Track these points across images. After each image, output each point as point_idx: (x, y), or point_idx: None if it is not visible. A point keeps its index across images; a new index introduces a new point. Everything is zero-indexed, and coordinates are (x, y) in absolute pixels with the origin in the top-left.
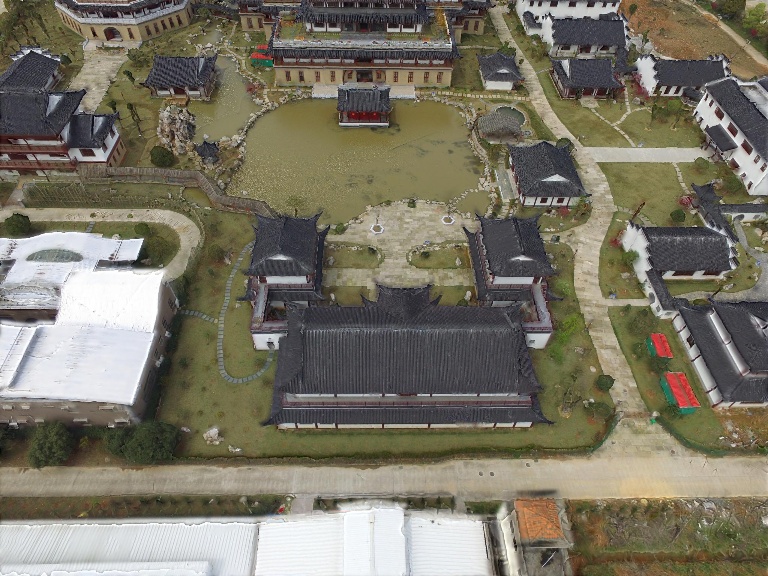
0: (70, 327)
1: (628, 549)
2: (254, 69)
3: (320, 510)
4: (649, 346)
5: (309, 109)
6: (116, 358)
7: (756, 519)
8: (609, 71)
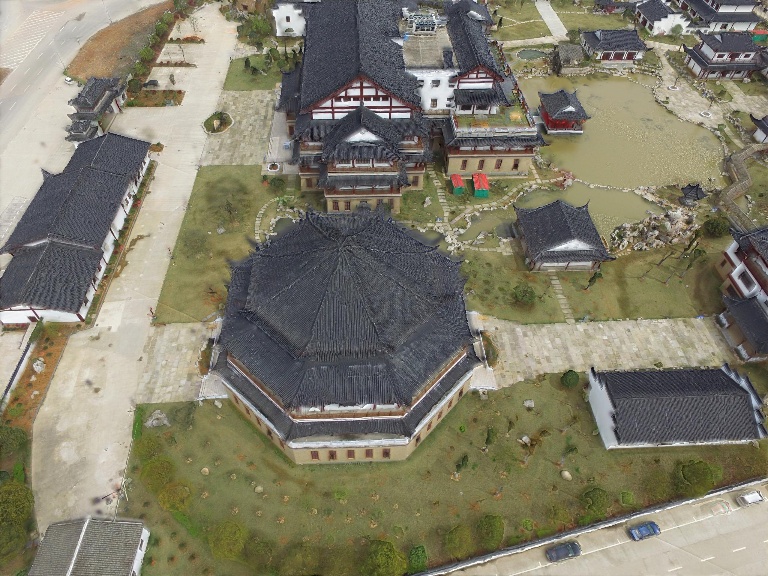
0: None
1: None
2: (496, 195)
3: None
4: None
5: None
6: None
7: None
8: (474, 3)
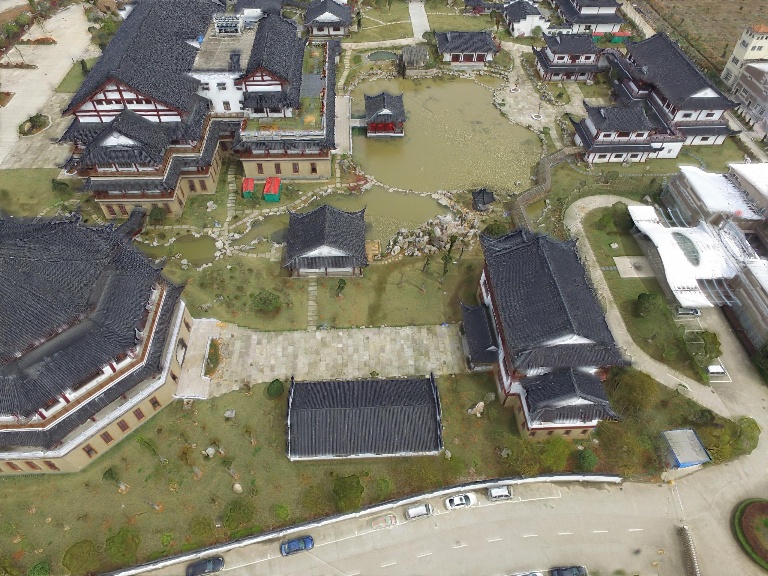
0: (762, 188)
1: (705, 59)
2: (289, 199)
3: (753, 129)
4: (594, 40)
5: (370, 158)
6: (761, 171)
7: (669, 34)
8: (336, 4)
